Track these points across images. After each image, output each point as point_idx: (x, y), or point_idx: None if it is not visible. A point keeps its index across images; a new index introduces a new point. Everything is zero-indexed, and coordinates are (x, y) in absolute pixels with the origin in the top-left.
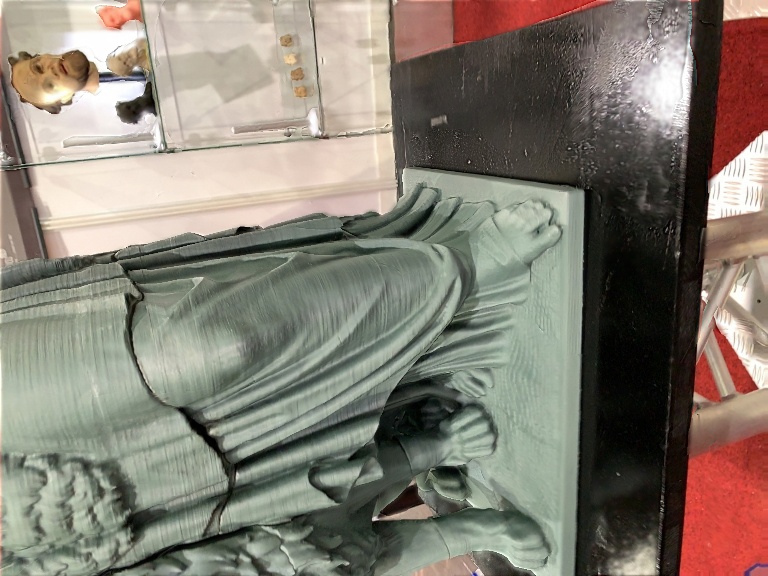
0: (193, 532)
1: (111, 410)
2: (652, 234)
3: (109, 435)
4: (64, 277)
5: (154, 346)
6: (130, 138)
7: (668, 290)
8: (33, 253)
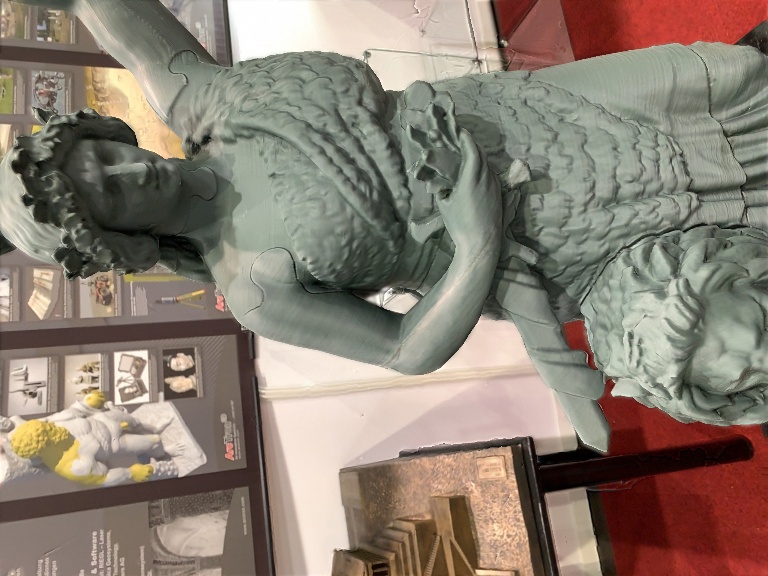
0: (735, 213)
1: (684, 78)
2: None
3: (670, 116)
4: None
5: (700, 46)
6: None
7: None
8: (249, 419)
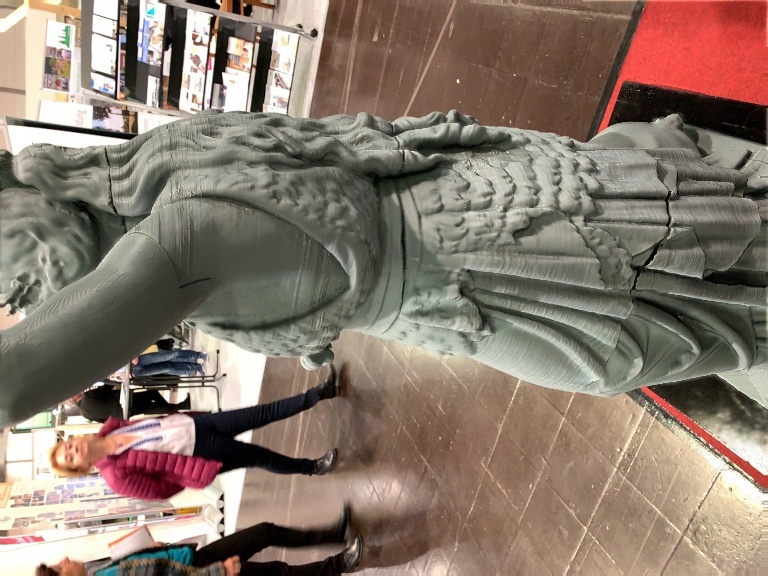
0: None
1: None
2: (760, 457)
3: None
4: (598, 307)
5: None
6: None
7: (732, 448)
8: None
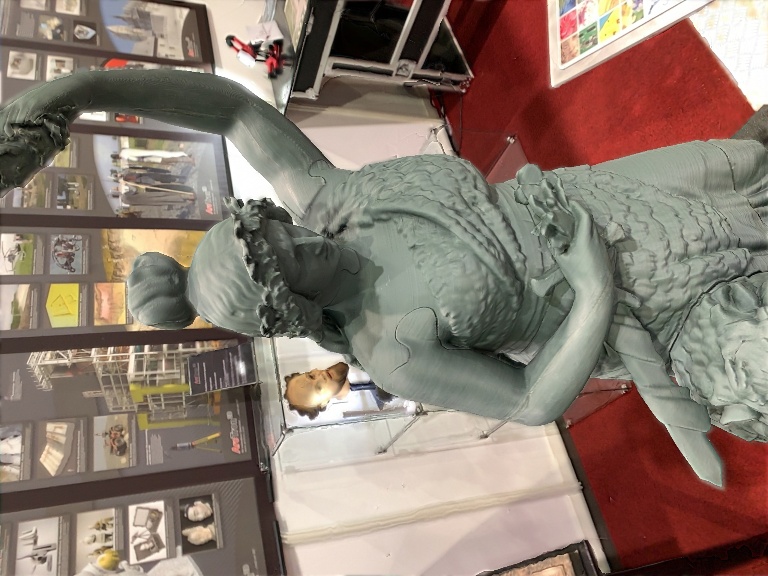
0: None
1: (712, 163)
2: None
3: None
4: None
5: (716, 141)
6: (389, 410)
7: None
8: (273, 568)
